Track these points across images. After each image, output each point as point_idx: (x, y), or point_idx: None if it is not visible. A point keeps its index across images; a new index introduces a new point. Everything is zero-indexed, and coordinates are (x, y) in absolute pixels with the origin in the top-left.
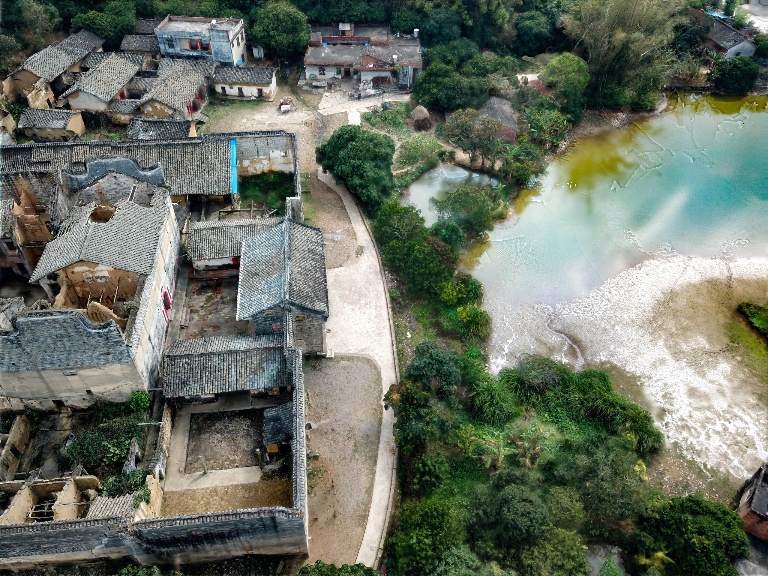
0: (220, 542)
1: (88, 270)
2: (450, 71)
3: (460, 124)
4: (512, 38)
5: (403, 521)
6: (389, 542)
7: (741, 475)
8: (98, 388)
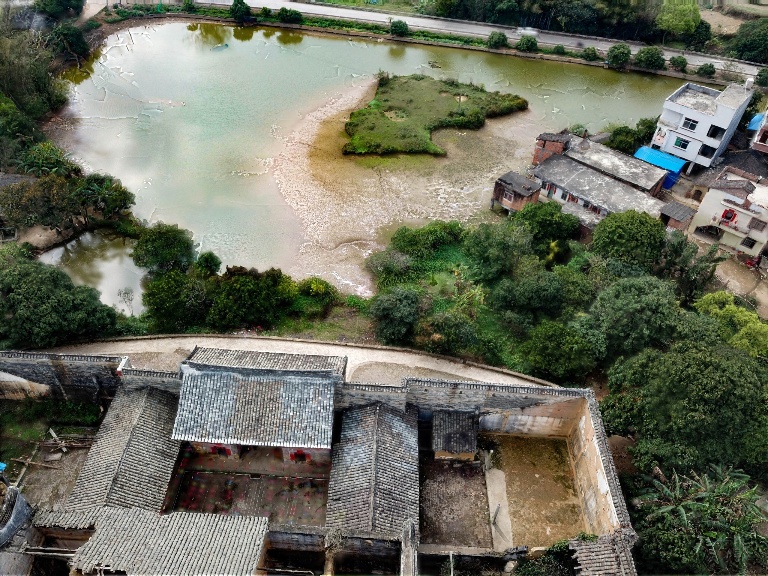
0: None
1: None
2: None
3: (29, 203)
4: None
5: (542, 364)
6: (563, 373)
7: (479, 205)
8: None
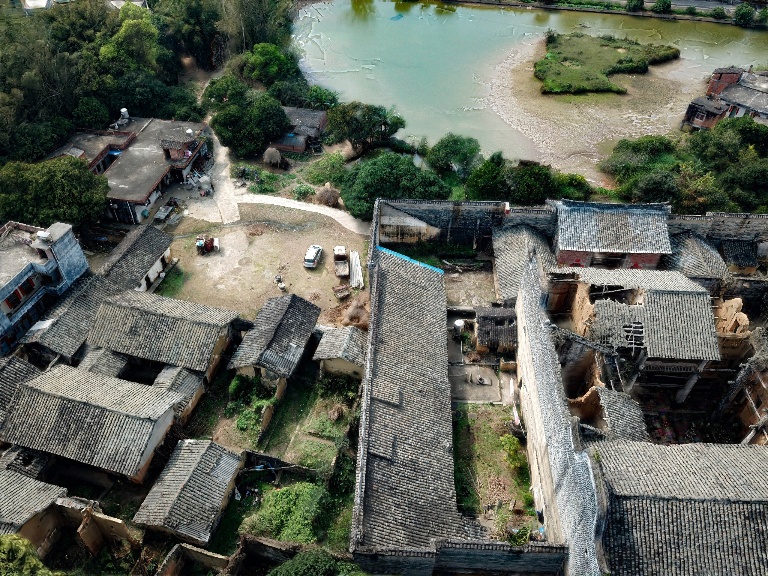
0: None
1: None
2: None
3: None
4: (163, 72)
5: None
6: None
7: (669, 127)
8: None
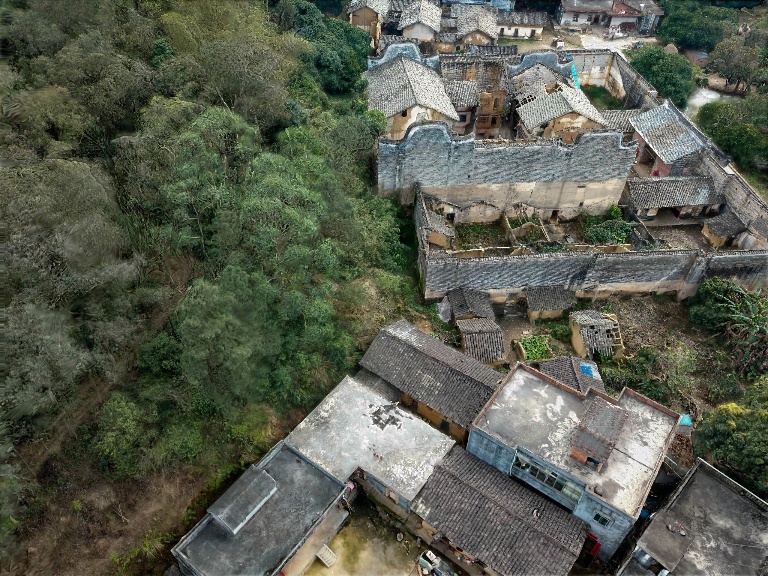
0: (743, 277)
1: (569, 121)
2: (692, 17)
3: (727, 52)
4: None
5: None
6: None
7: None
8: (589, 201)
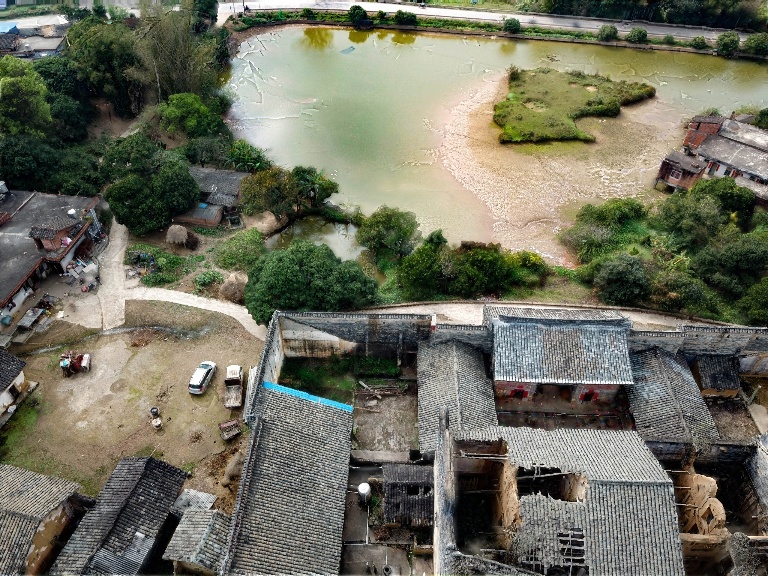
0: None
1: None
2: None
3: (267, 192)
4: (65, 128)
5: (765, 316)
6: None
7: (641, 184)
8: None
